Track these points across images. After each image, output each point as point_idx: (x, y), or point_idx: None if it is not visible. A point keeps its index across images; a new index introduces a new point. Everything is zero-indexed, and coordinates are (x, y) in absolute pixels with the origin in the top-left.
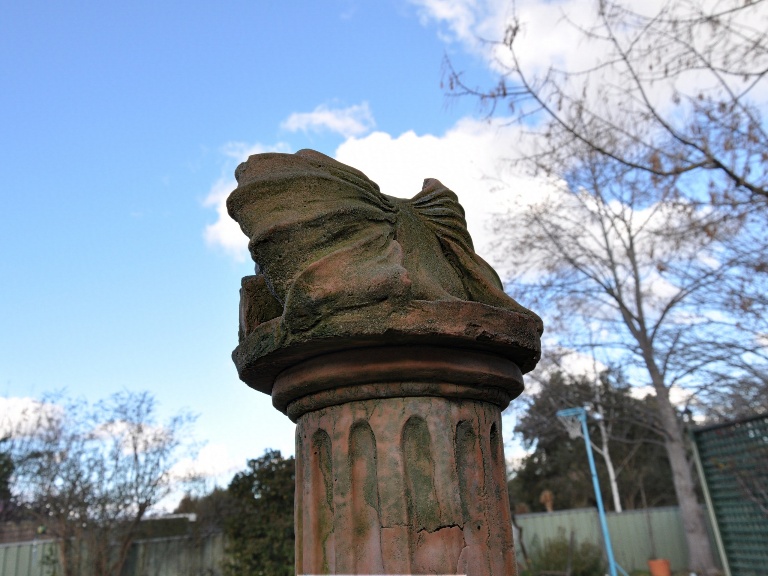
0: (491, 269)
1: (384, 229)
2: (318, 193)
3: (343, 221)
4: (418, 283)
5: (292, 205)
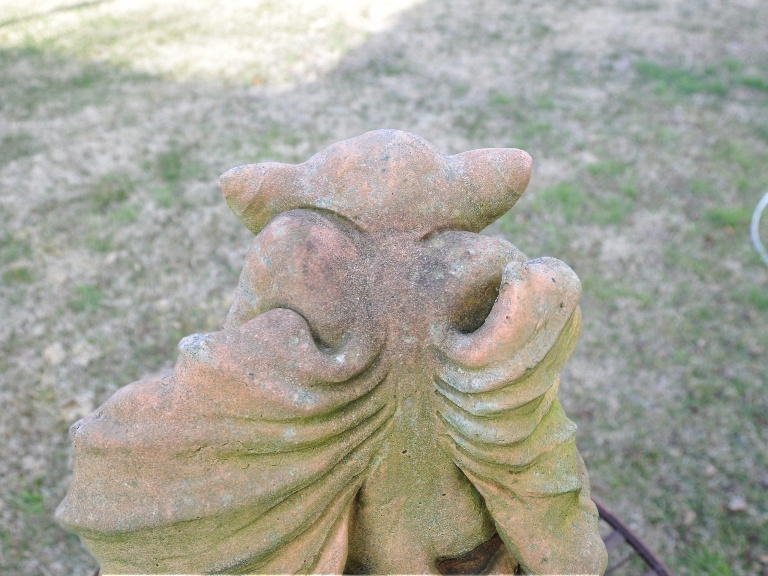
0: (555, 493)
1: (312, 542)
2: (177, 544)
3: (224, 573)
4: (381, 561)
5: (137, 562)
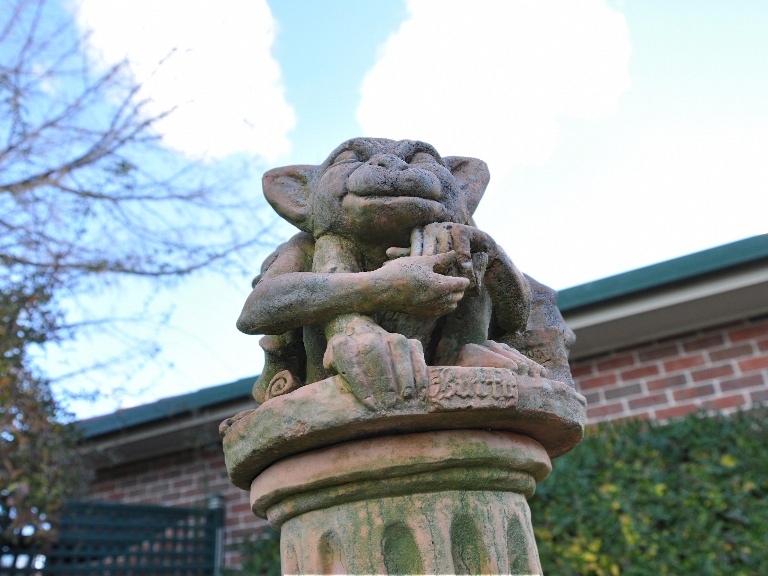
0: None
1: None
2: None
3: None
4: None
5: None
